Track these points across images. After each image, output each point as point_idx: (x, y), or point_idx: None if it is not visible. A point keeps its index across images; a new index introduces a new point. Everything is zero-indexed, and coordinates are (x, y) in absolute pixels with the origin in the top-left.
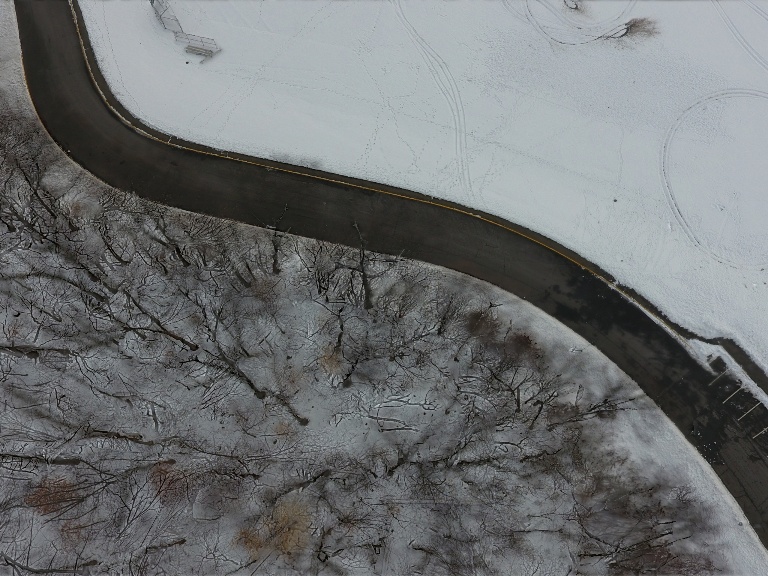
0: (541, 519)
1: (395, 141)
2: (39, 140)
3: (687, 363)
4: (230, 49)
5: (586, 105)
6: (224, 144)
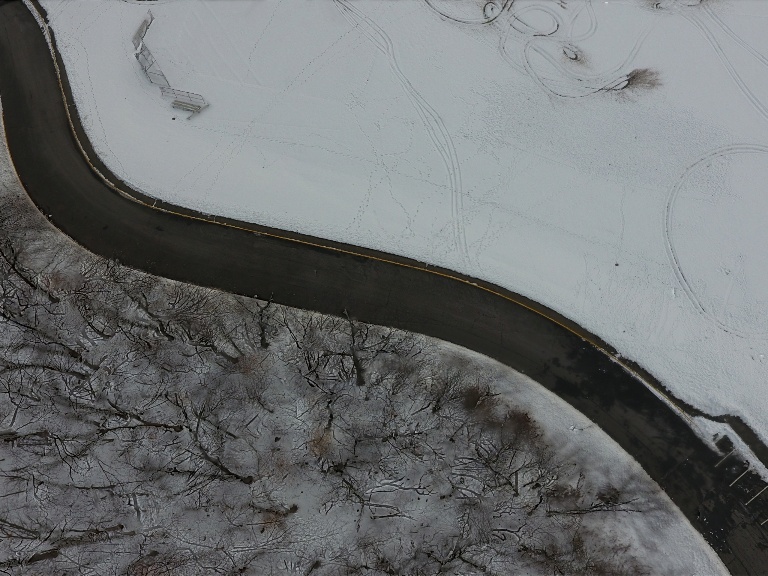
0: None
1: (389, 202)
2: (19, 204)
3: (692, 442)
4: (218, 104)
5: (586, 162)
6: (211, 208)
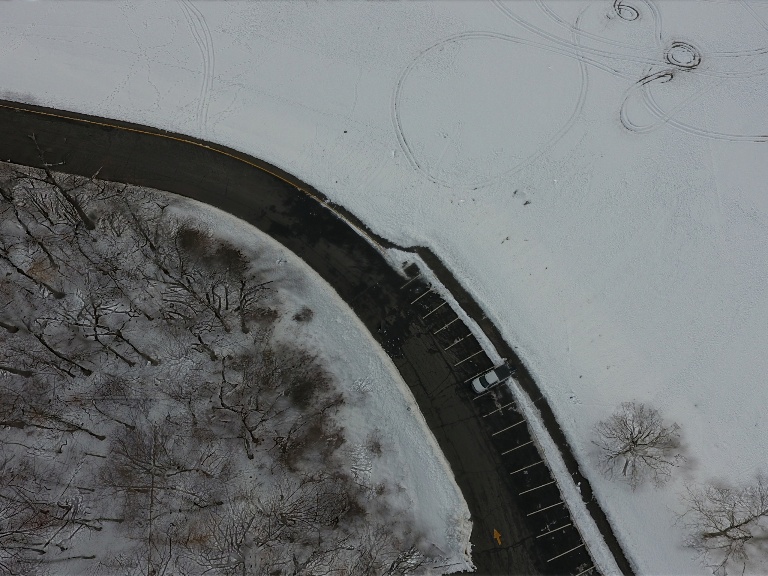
0: (226, 411)
1: (144, 85)
2: None
3: (383, 270)
4: (4, 10)
5: (330, 49)
6: None
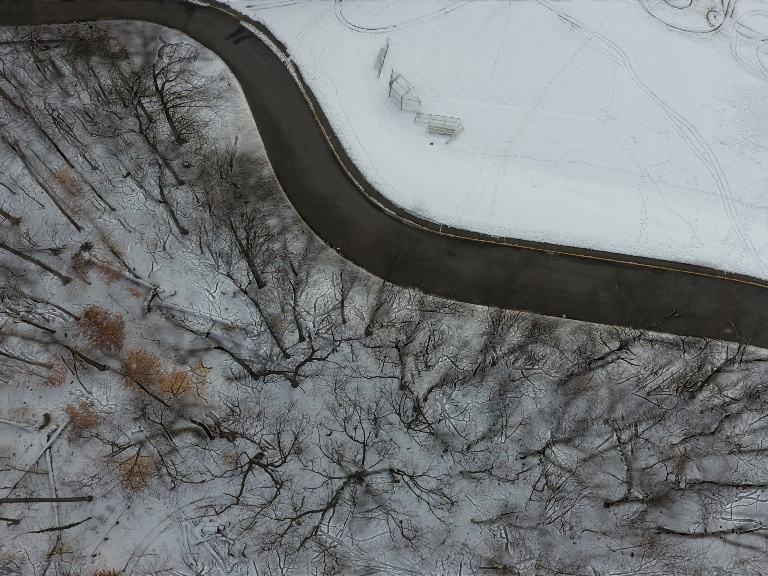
0: None
1: (666, 213)
2: (305, 239)
3: None
4: (472, 126)
5: None
6: (499, 230)
